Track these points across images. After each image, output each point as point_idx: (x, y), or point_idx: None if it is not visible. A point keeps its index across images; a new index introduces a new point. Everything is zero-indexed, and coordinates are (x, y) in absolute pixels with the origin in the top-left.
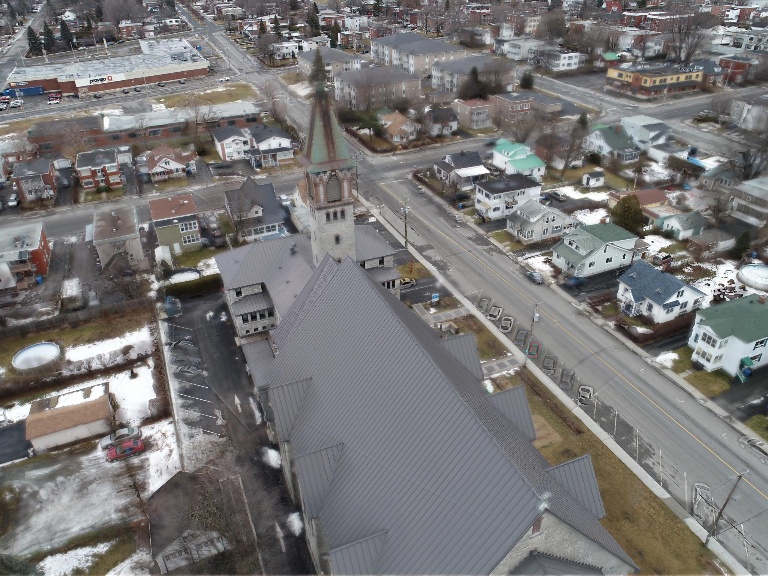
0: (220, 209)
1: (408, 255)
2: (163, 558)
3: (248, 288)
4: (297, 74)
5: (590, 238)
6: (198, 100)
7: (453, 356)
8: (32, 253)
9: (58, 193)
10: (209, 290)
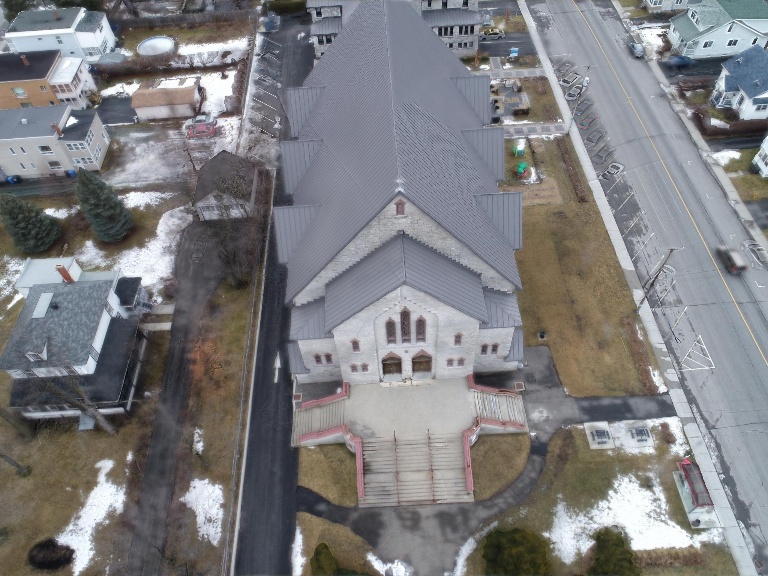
0: None
1: (514, 6)
2: (200, 208)
3: (328, 9)
4: None
5: (718, 11)
6: None
7: (463, 95)
8: None
9: None
10: None
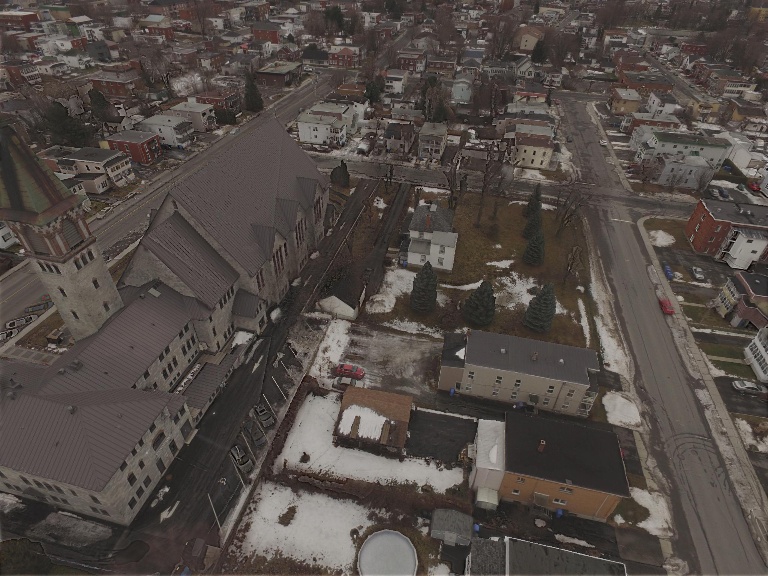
0: None
1: None
2: None
3: None
4: None
5: None
6: None
7: None
8: None
9: None
10: None
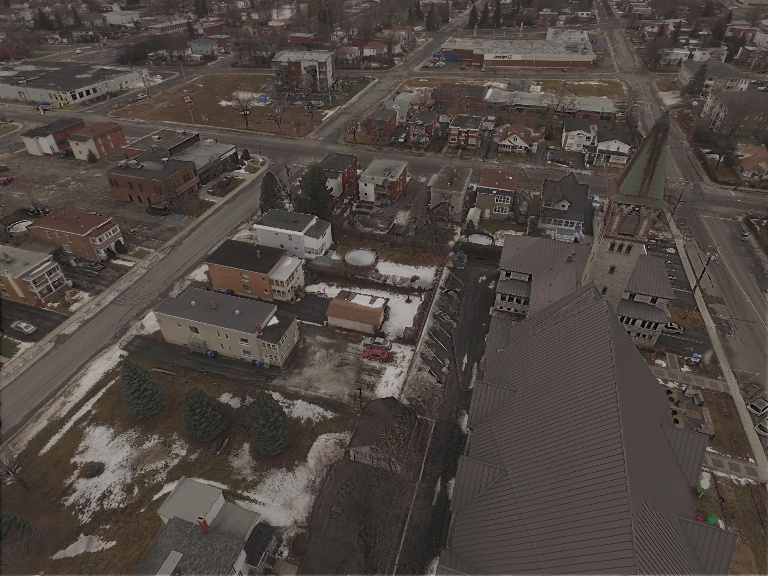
0: (537, 191)
1: (691, 300)
2: (354, 451)
3: (517, 274)
4: (673, 82)
5: None
6: (565, 91)
7: (671, 446)
8: (391, 183)
9: (432, 141)
10: (493, 257)
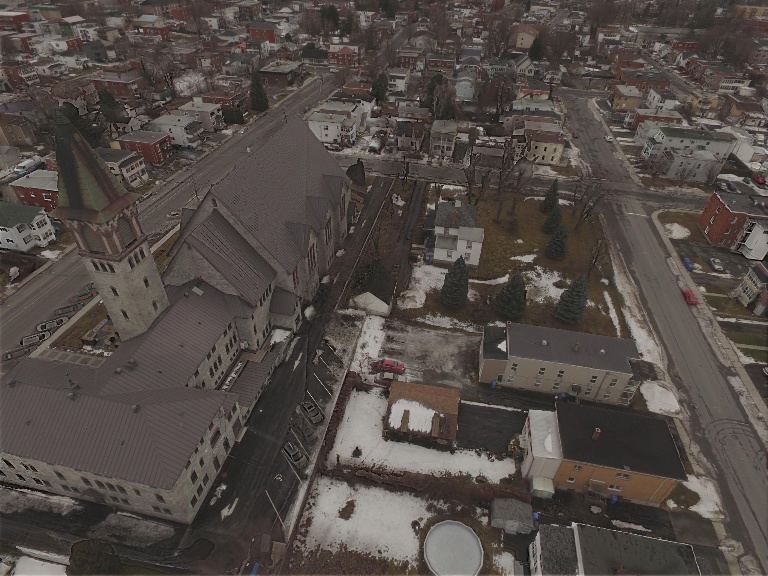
0: None
1: None
2: None
3: None
4: None
5: None
6: None
7: None
8: None
9: None
10: None
